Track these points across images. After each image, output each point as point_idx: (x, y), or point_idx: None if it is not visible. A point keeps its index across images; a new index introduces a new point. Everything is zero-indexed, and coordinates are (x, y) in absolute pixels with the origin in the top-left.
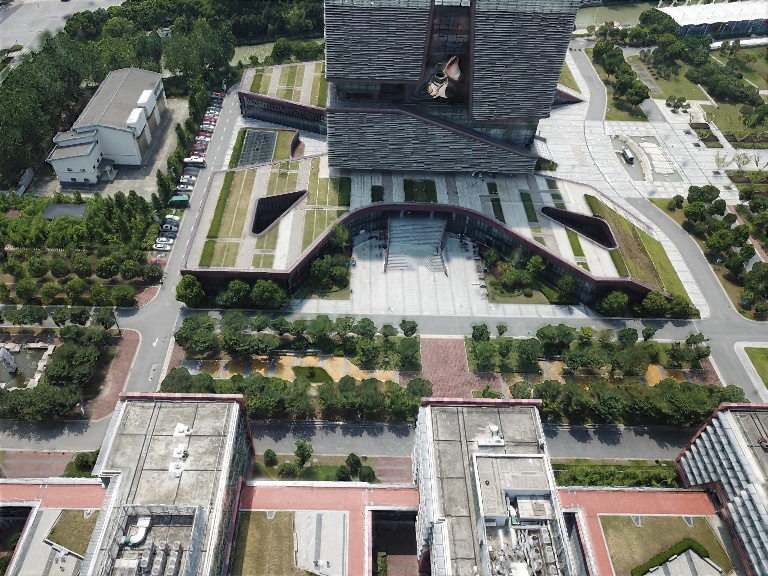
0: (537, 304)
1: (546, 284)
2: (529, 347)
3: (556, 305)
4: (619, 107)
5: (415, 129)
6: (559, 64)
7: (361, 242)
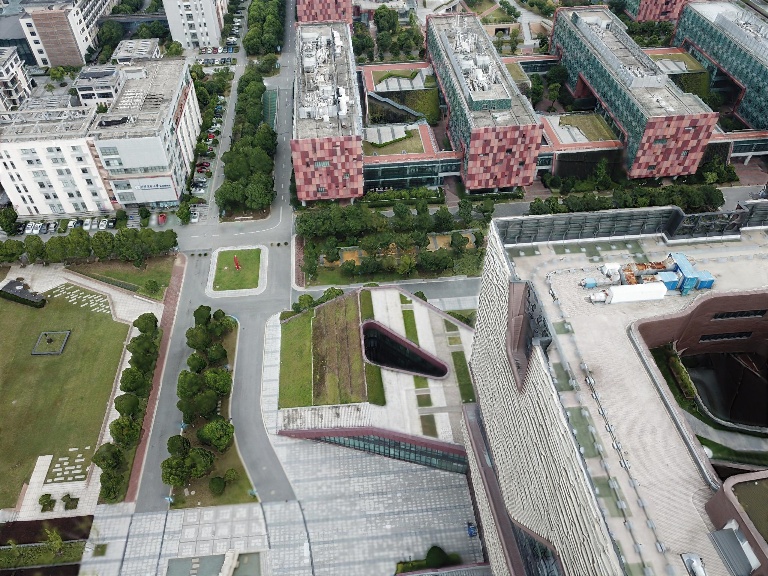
0: None
1: None
2: None
3: None
4: None
5: None
6: None
7: None
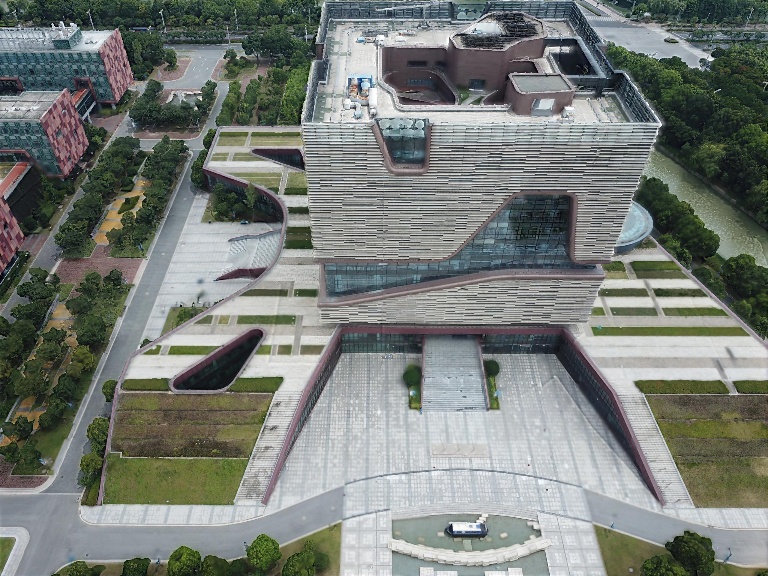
0: None
1: None
2: (75, 298)
3: None
4: None
5: None
6: None
7: (273, 228)
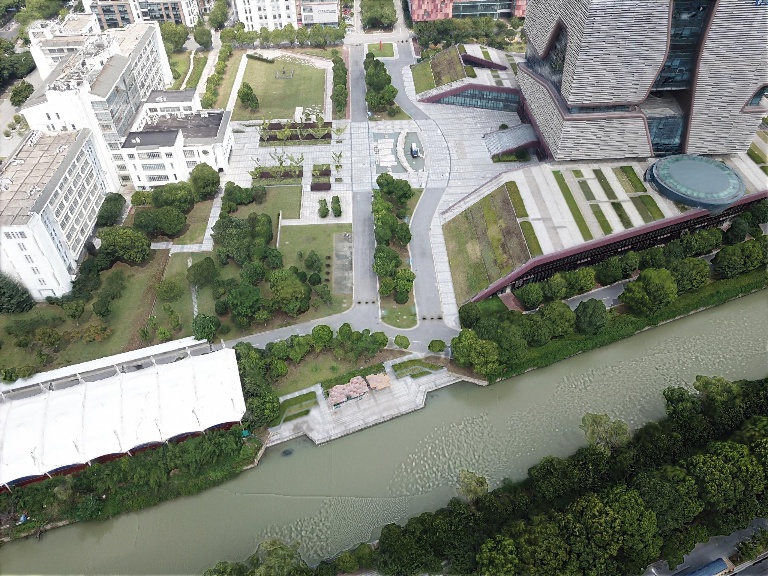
0: None
1: None
2: None
3: None
4: None
5: None
6: None
7: None
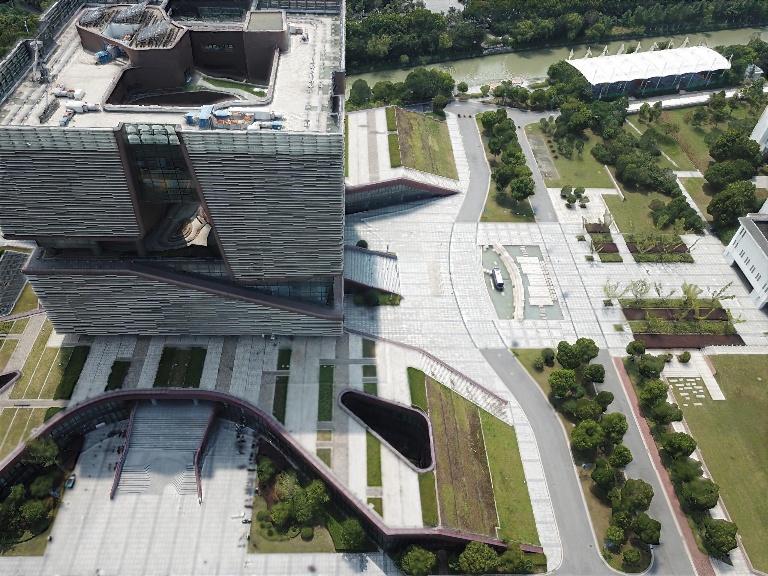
0: (316, 553)
1: (336, 515)
2: None
3: (344, 553)
4: (501, 202)
5: (159, 291)
6: (336, 215)
7: (96, 442)
